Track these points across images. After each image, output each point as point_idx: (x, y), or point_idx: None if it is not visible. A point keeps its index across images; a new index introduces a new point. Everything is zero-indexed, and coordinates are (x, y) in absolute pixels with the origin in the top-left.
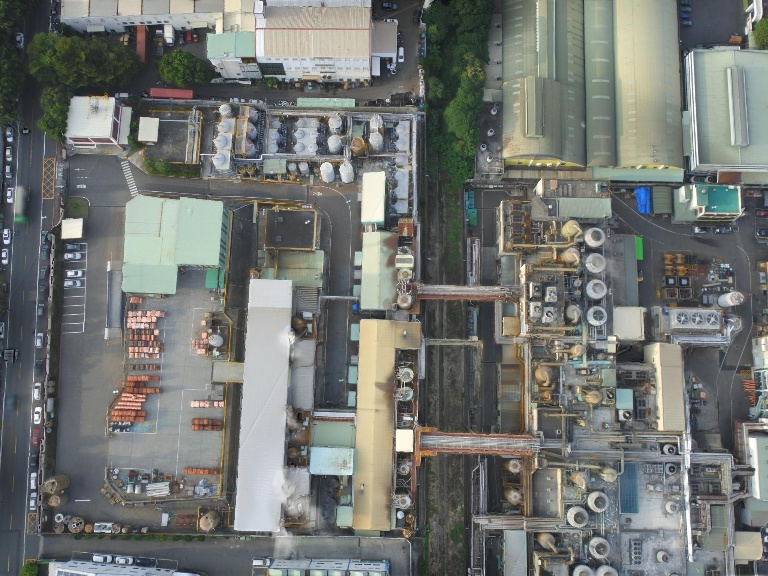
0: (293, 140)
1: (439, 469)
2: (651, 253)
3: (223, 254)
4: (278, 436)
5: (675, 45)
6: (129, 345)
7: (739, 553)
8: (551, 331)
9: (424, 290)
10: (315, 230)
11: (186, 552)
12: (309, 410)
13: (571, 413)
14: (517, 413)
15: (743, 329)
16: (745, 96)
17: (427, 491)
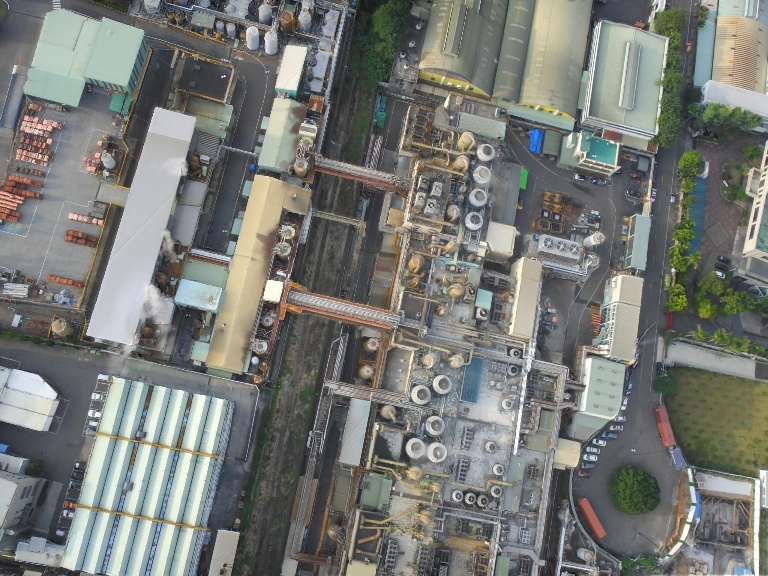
0: (226, 3)
1: (302, 335)
2: (534, 188)
3: (134, 81)
4: (150, 256)
5: (588, 14)
6: (18, 147)
7: (558, 457)
8: (430, 224)
9: (321, 162)
10: (229, 85)
11: (31, 355)
12: (187, 246)
13: (433, 299)
14: (385, 298)
15: (599, 267)
16: (637, 68)
17: (286, 351)
